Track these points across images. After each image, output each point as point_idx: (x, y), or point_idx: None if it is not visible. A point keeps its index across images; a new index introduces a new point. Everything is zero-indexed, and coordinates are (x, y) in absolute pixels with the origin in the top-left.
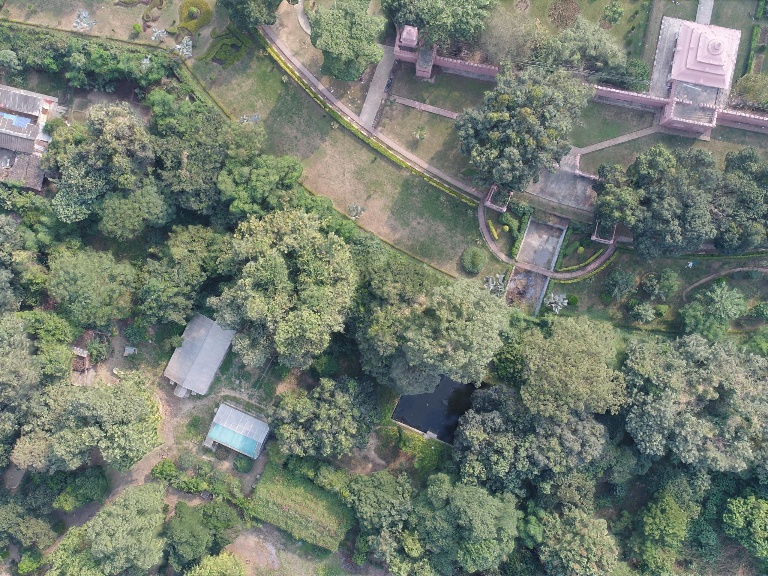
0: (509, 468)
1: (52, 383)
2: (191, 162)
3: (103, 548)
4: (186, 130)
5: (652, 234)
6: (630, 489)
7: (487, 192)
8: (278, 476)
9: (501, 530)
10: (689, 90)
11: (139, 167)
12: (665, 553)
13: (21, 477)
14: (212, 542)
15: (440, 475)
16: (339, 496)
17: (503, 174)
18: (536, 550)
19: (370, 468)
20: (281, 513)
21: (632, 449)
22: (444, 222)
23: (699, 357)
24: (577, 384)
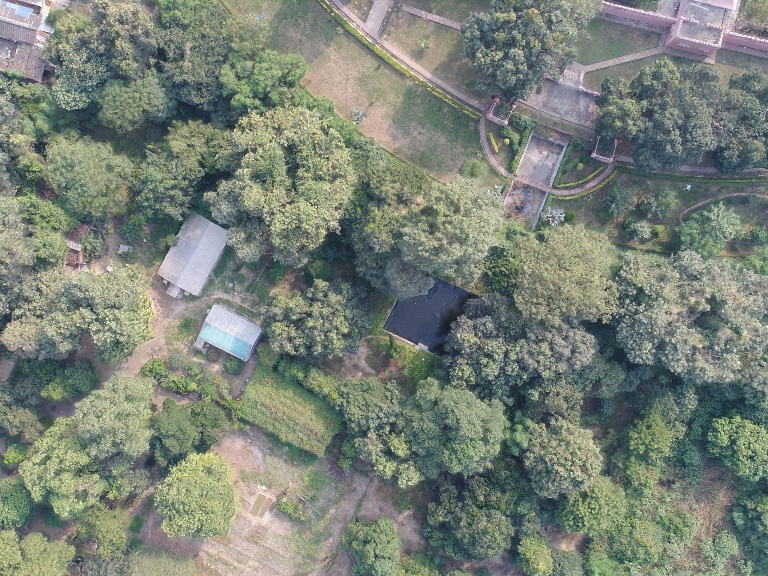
0: (498, 373)
1: (45, 270)
2: (194, 54)
3: (90, 428)
4: (190, 23)
5: (652, 145)
6: (617, 408)
7: (489, 105)
8: (268, 378)
9: (488, 432)
10: (696, 9)
11: (141, 56)
12: (649, 471)
13: (10, 371)
14: (199, 440)
15: (429, 379)
16: (328, 398)
17: (507, 76)
18: (521, 456)
19: (360, 377)
20: (269, 415)
21: (621, 367)
22: (445, 133)
23: (693, 270)
24: (570, 288)
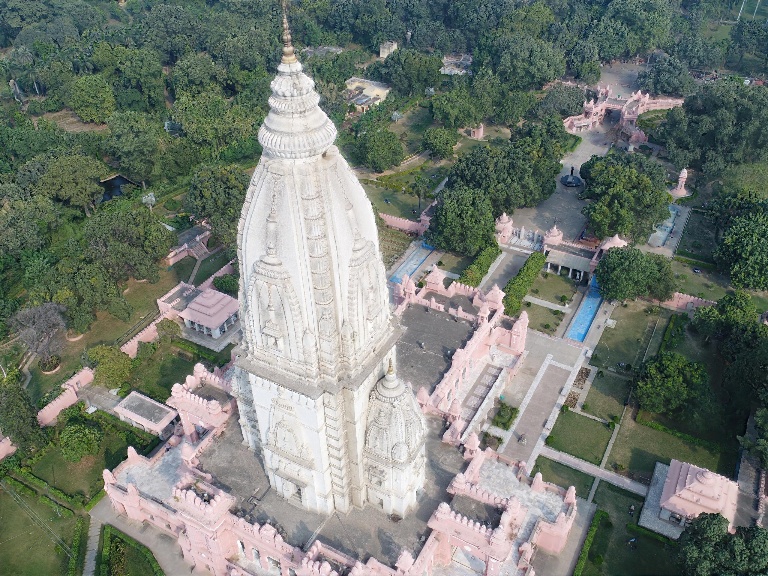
0: None
1: None
2: None
3: None
4: None
5: None
6: None
7: None
8: None
9: None
10: None
11: None
12: None
13: None
14: None
15: None
16: (99, 135)
17: None
18: None
19: None
20: None
21: None
22: None
23: None
24: None
